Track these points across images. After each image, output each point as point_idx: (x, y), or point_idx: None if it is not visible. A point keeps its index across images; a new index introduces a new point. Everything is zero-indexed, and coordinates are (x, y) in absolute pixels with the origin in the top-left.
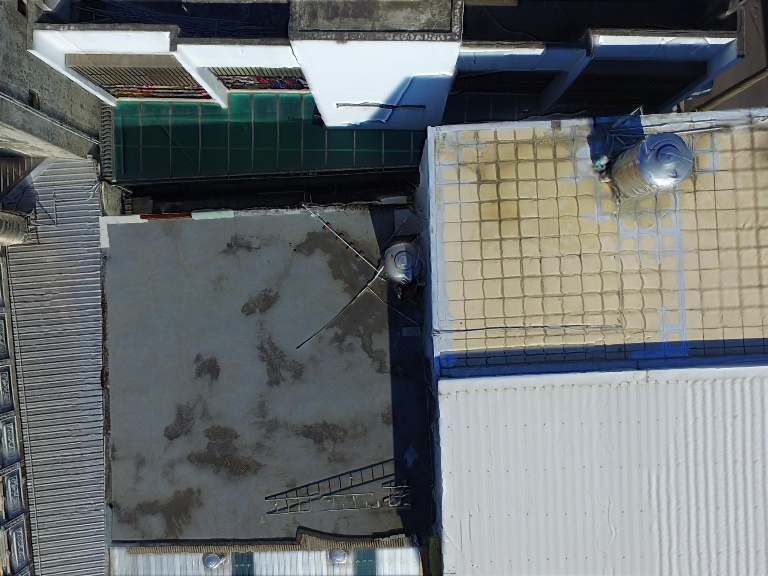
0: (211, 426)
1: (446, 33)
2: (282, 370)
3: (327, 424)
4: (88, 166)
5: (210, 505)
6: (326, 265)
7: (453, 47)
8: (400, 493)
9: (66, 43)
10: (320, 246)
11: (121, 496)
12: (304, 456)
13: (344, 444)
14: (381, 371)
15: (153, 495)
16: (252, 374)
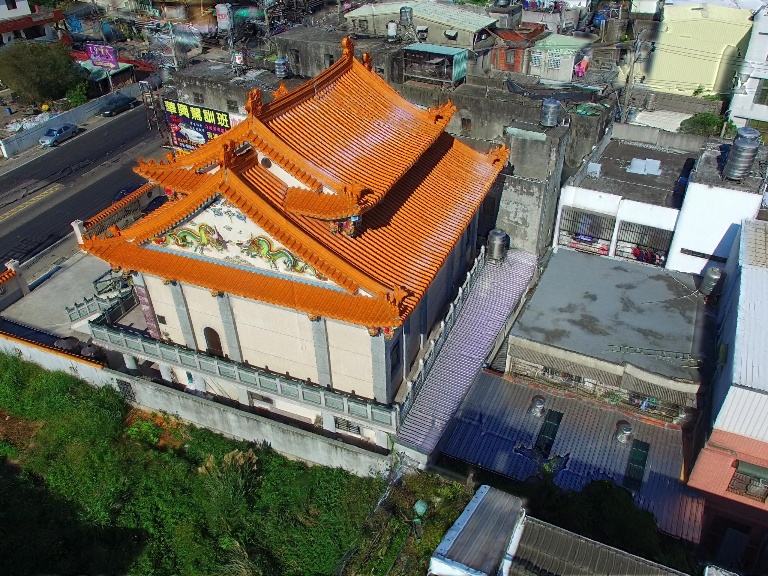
0: (585, 314)
1: (756, 192)
2: (632, 308)
3: (653, 331)
4: (534, 258)
5: (574, 339)
6: (665, 285)
7: (758, 200)
8: (693, 365)
9: (573, 196)
10: (664, 279)
11: (525, 321)
12: (636, 338)
13: (661, 340)
14: (689, 323)
15: (543, 326)
16: (614, 305)
